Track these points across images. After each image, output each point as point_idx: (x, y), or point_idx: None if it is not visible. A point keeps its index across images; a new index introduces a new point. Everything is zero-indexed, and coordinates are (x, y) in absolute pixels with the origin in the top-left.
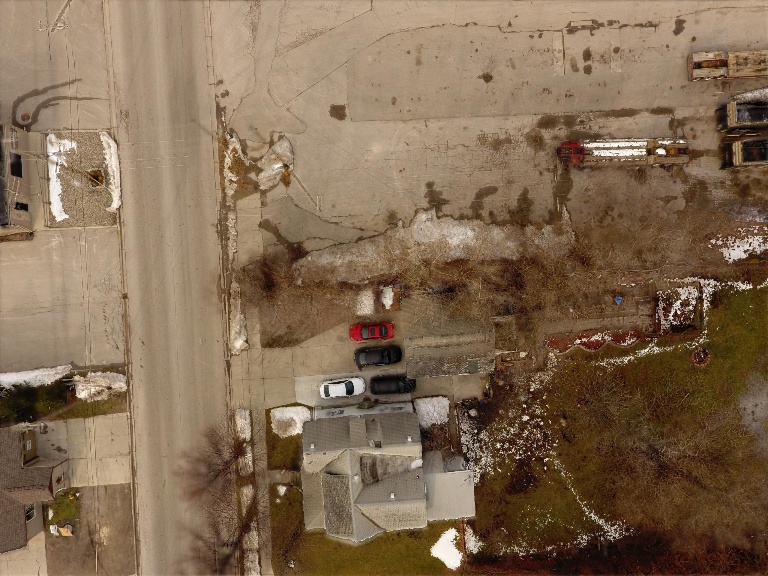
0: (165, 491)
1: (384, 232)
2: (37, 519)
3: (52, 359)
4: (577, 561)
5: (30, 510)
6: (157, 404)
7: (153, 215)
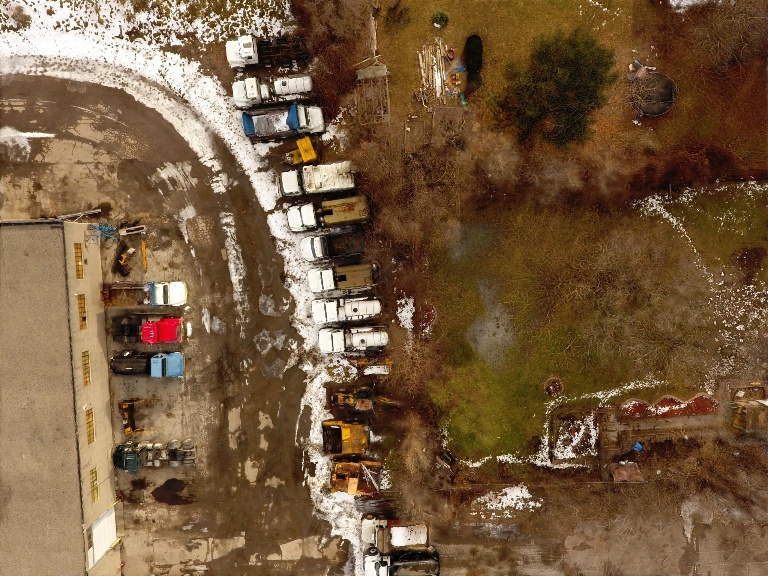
0: None
1: None
2: None
3: None
4: None
5: None
6: None
7: None
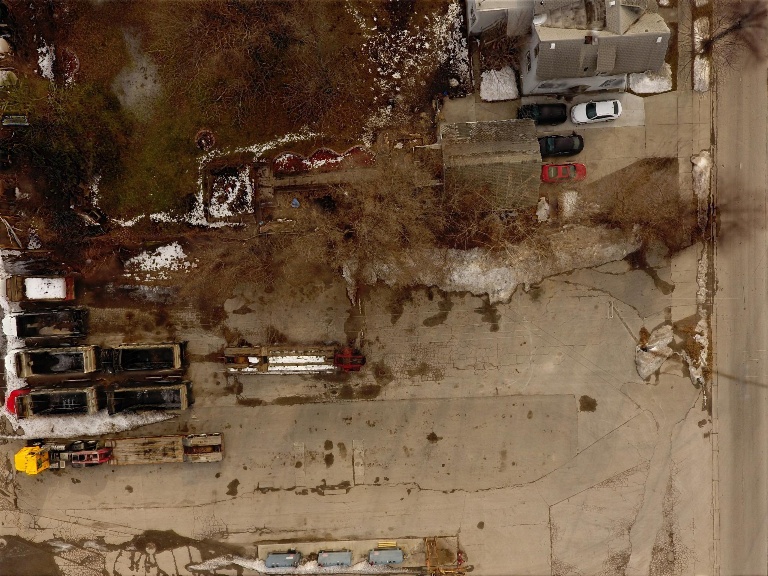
0: None
1: (544, 279)
2: None
3: None
4: None
5: None
6: None
7: None
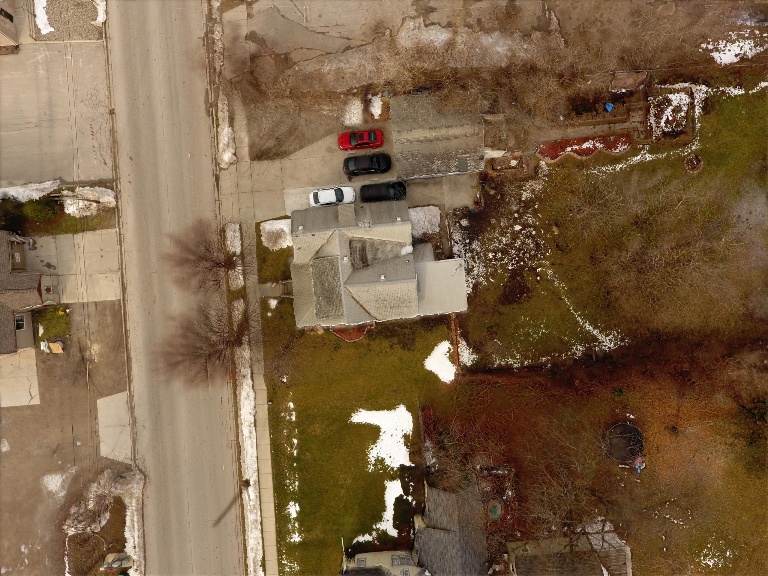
0: (156, 307)
1: (371, 41)
2: (27, 333)
3: (40, 174)
4: (572, 370)
5: (20, 320)
6: (146, 220)
7: (139, 29)
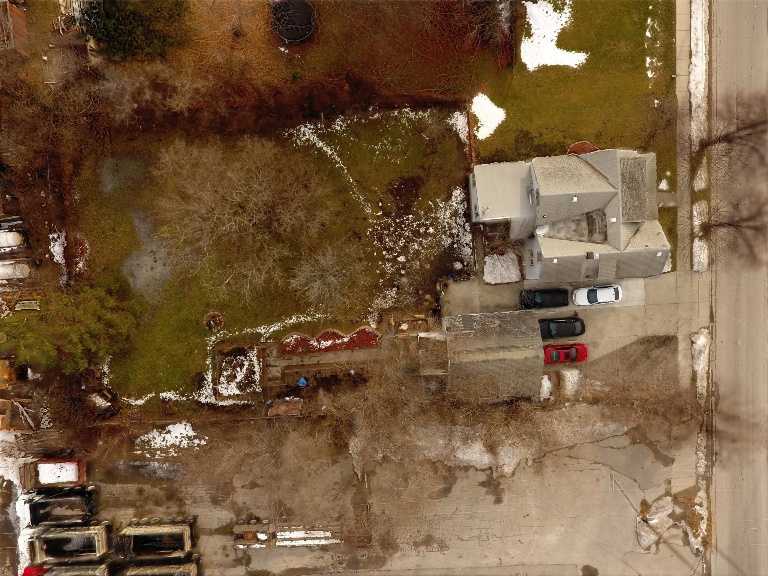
0: None
1: (547, 454)
2: None
3: None
4: (349, 103)
5: None
6: None
7: None
